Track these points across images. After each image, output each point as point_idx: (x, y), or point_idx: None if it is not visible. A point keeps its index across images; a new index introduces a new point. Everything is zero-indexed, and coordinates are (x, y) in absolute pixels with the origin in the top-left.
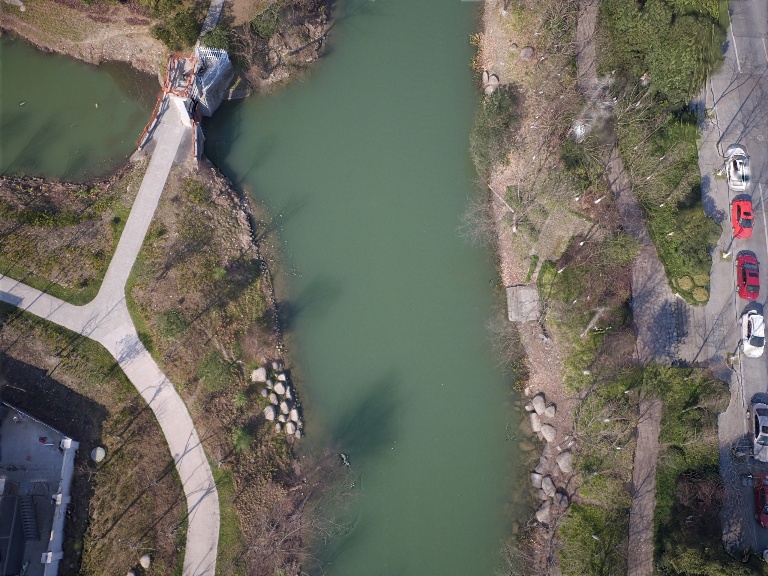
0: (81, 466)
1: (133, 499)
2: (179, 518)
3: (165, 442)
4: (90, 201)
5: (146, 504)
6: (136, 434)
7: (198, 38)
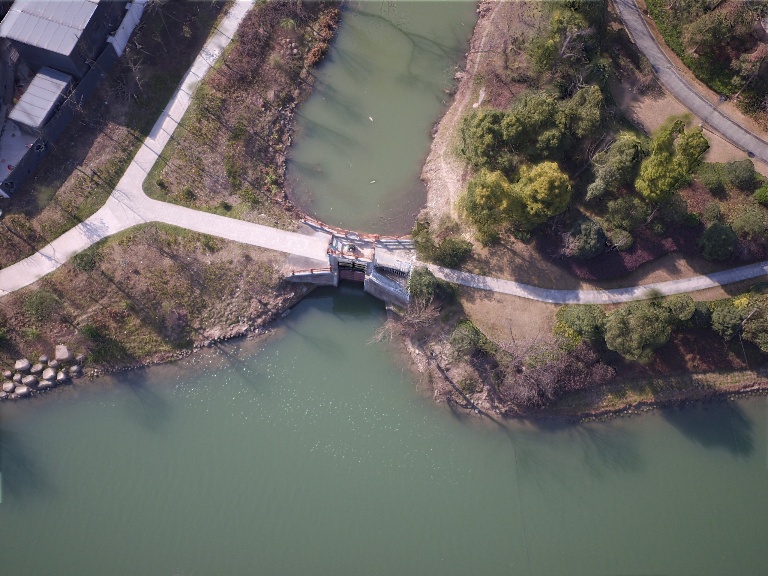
0: None
1: None
2: None
3: (0, 268)
4: (259, 185)
5: None
6: (8, 242)
7: (441, 267)
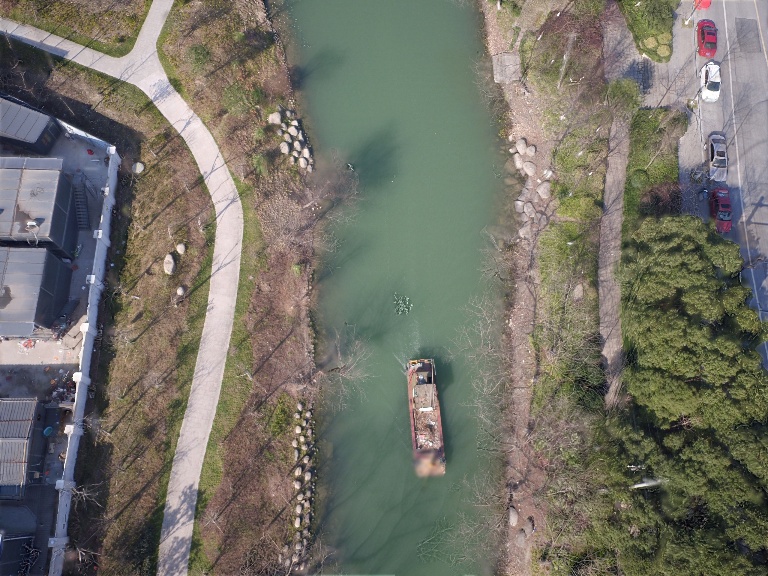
0: (123, 178)
1: (169, 202)
2: (208, 220)
3: (195, 162)
4: None
5: (180, 207)
6: (170, 153)
7: None
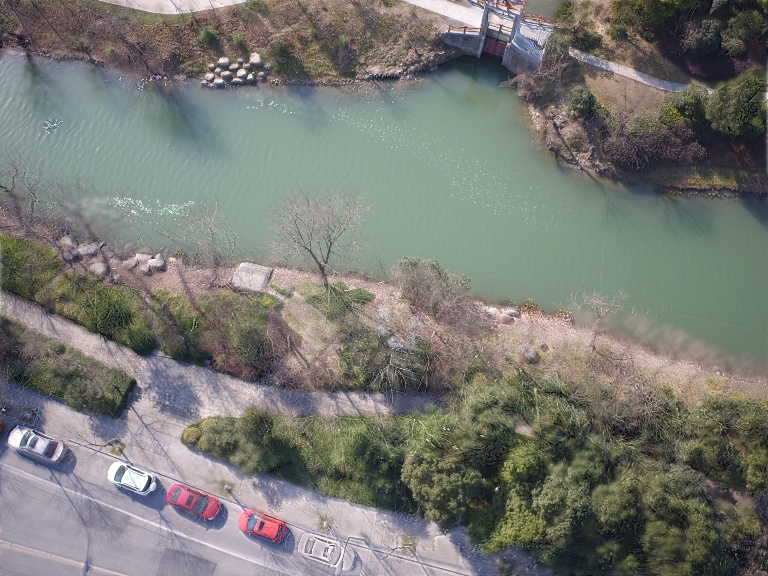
0: None
1: None
2: None
3: None
4: None
5: None
6: None
7: (573, 48)
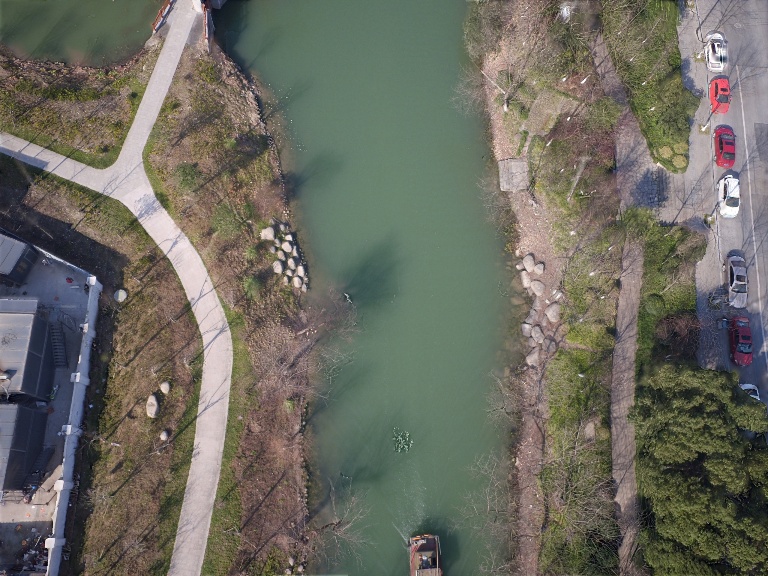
0: (105, 307)
1: (153, 334)
2: (195, 353)
3: (182, 287)
4: (109, 81)
5: (165, 339)
6: (155, 279)
7: None
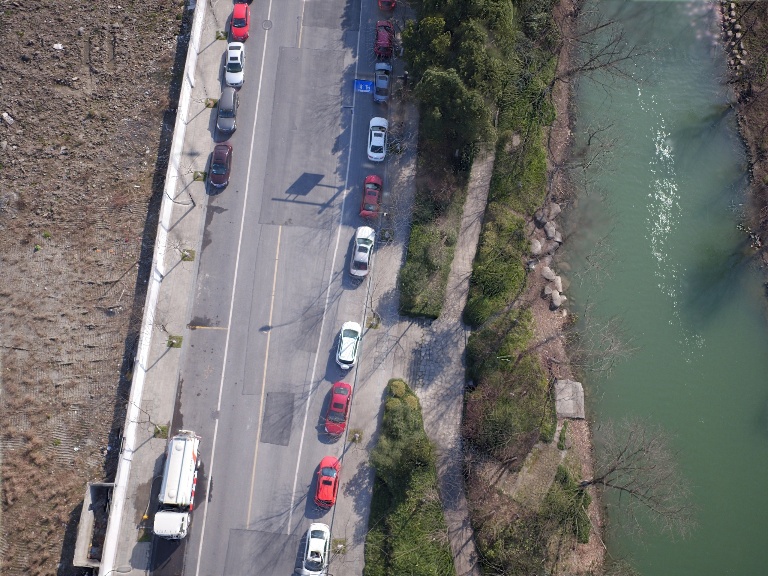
0: None
1: None
2: None
3: None
4: None
5: None
6: None
7: None
